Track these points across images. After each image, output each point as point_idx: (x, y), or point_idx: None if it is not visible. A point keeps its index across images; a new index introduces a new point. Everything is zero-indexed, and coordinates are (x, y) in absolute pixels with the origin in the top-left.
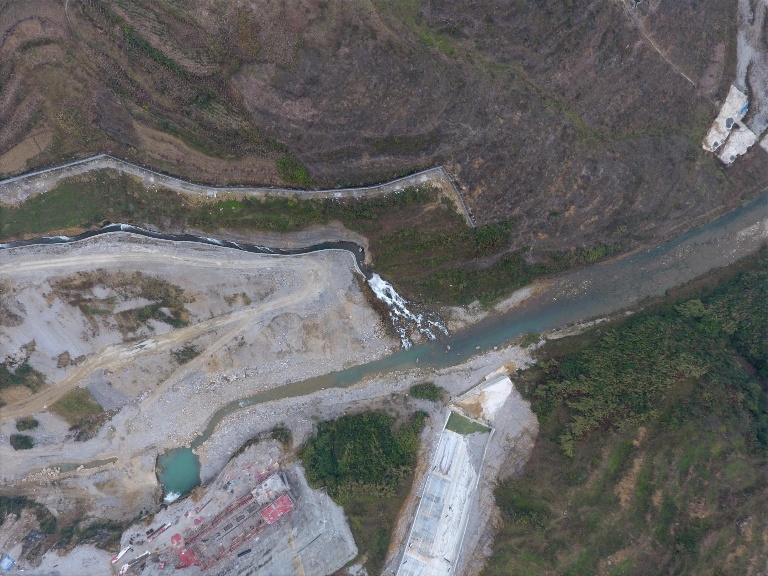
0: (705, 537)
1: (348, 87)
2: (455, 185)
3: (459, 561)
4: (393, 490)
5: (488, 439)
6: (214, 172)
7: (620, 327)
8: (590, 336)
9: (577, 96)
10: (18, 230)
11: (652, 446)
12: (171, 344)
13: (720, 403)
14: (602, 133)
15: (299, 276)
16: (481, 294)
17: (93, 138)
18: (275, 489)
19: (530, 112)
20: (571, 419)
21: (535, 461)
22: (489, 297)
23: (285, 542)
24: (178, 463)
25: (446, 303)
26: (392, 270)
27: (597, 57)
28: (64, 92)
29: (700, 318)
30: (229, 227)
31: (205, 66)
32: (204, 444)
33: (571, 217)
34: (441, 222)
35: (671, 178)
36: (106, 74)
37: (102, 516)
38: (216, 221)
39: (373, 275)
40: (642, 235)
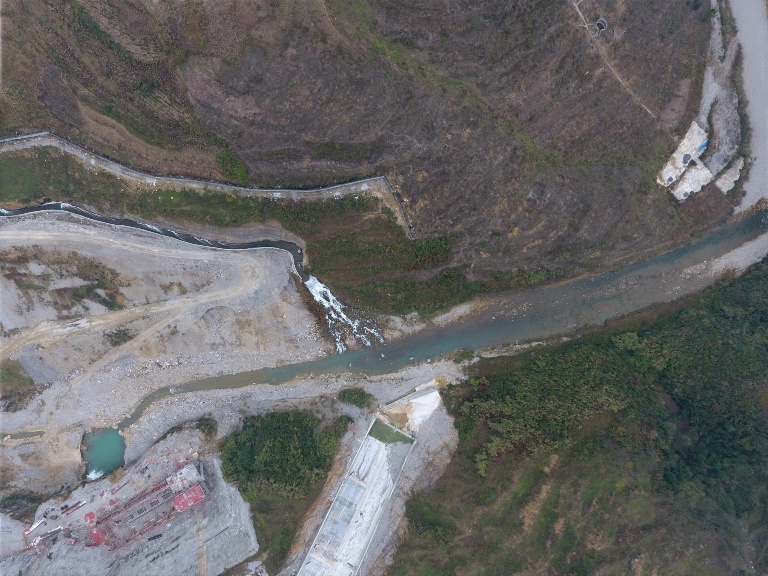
0: (598, 569)
1: (292, 89)
2: (396, 196)
3: (362, 567)
4: (302, 492)
5: (409, 450)
6: (154, 160)
7: (554, 352)
8: (524, 358)
9: (530, 118)
10: None
11: (561, 474)
12: (105, 325)
13: (633, 439)
14: (554, 157)
15: (236, 271)
16: (419, 306)
17: (37, 115)
18: (190, 478)
19: (480, 130)
20: (489, 439)
21: (448, 477)
22: (427, 310)
23: (194, 531)
24: (104, 442)
25: (384, 311)
26: (329, 274)
27: (554, 81)
28: (12, 66)
29: (633, 351)
30: (167, 216)
31: (151, 54)
32: (131, 426)
33: (514, 239)
34: (380, 231)
35: (620, 209)
36: (54, 52)
37: (24, 487)
38: (154, 209)
39: (310, 277)
40: (586, 263)
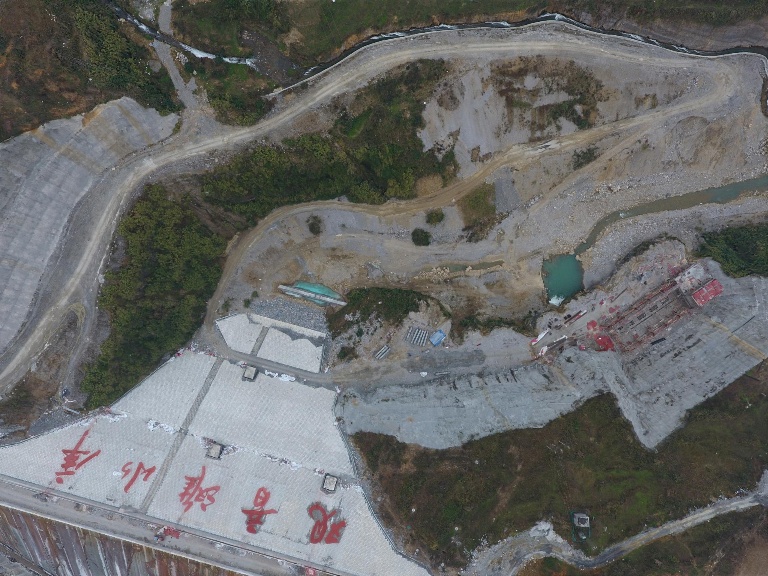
0: None
1: None
2: None
3: None
4: None
5: None
6: None
7: None
8: None
9: None
10: (473, 10)
11: None
12: (575, 145)
13: None
14: None
15: (711, 79)
16: None
17: None
18: (698, 277)
19: None
20: None
21: None
22: None
23: (709, 327)
24: (561, 269)
25: None
26: None
27: None
28: None
29: None
30: (669, 17)
31: None
32: (588, 251)
33: None
34: None
35: None
36: None
37: (493, 314)
38: (660, 9)
39: None
40: None
